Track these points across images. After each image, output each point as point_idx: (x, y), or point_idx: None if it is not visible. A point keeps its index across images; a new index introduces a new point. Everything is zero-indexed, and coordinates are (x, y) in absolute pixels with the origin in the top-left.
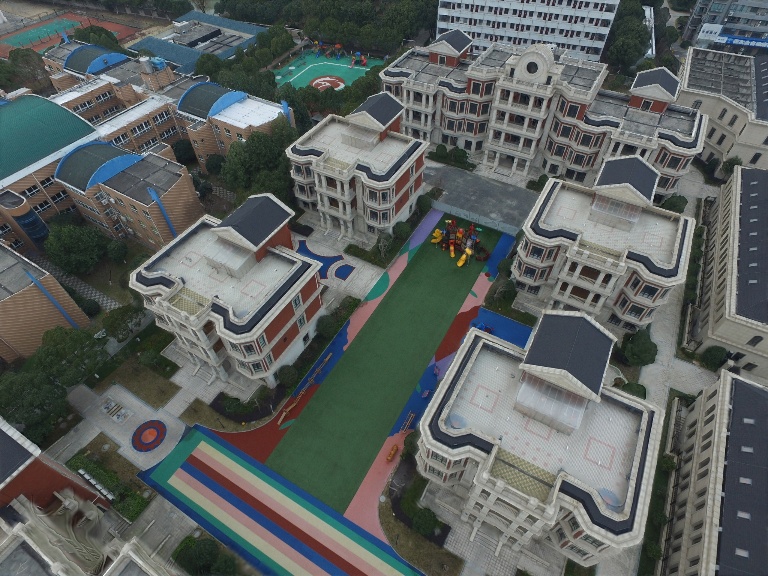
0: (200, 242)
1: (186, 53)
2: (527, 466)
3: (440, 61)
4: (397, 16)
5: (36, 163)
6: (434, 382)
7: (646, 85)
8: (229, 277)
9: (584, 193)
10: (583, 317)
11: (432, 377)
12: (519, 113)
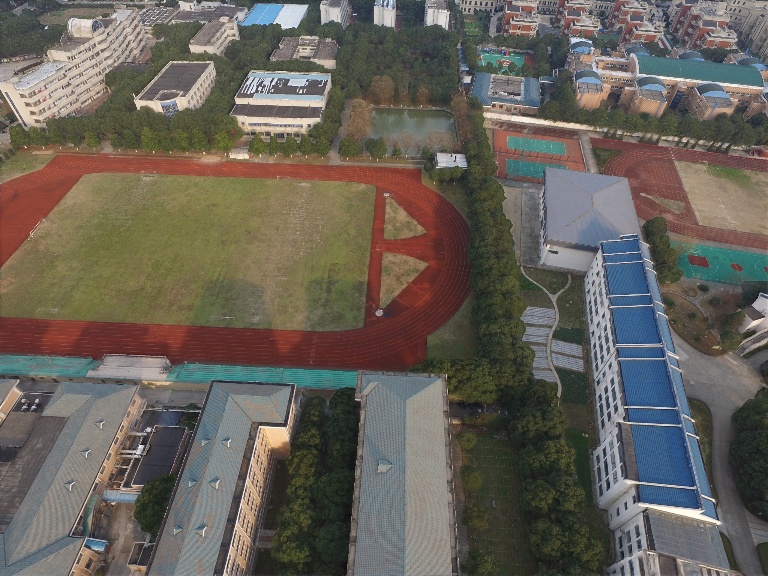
0: None
1: (534, 83)
2: None
3: None
4: None
5: None
6: None
7: None
8: None
9: None
10: None
11: None
12: None
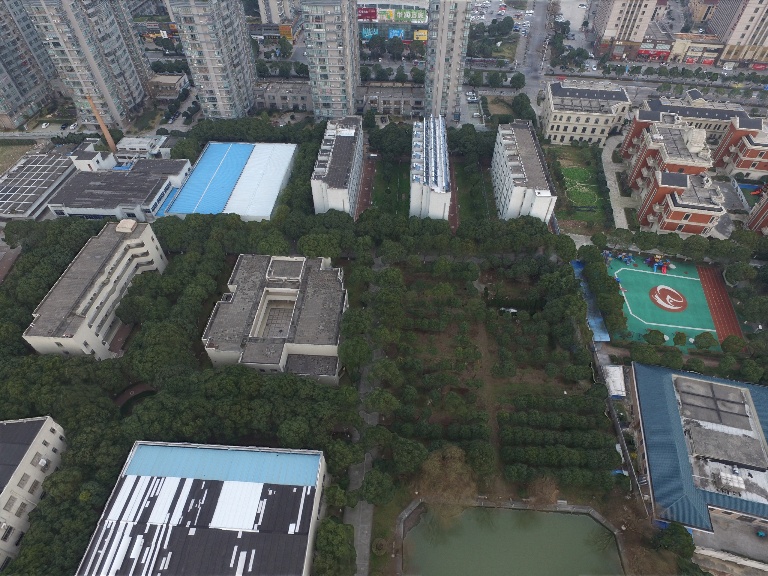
0: None
1: None
2: None
3: None
4: None
5: None
6: None
7: (660, 115)
8: None
9: None
10: None
11: None
12: None
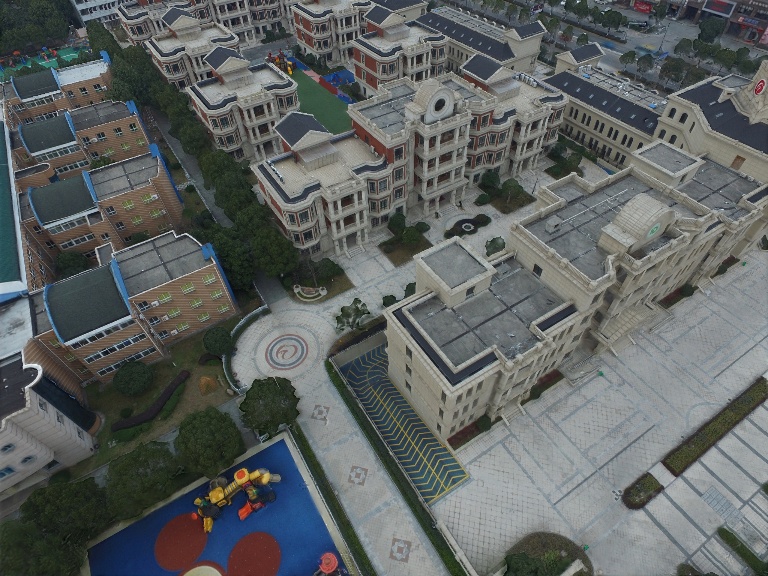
0: (208, 91)
1: None
2: (412, 46)
3: (149, 2)
4: (44, 11)
5: (7, 149)
6: (347, 98)
7: None
8: (249, 85)
9: (309, 4)
10: (376, 6)
11: (344, 98)
12: (232, 1)
